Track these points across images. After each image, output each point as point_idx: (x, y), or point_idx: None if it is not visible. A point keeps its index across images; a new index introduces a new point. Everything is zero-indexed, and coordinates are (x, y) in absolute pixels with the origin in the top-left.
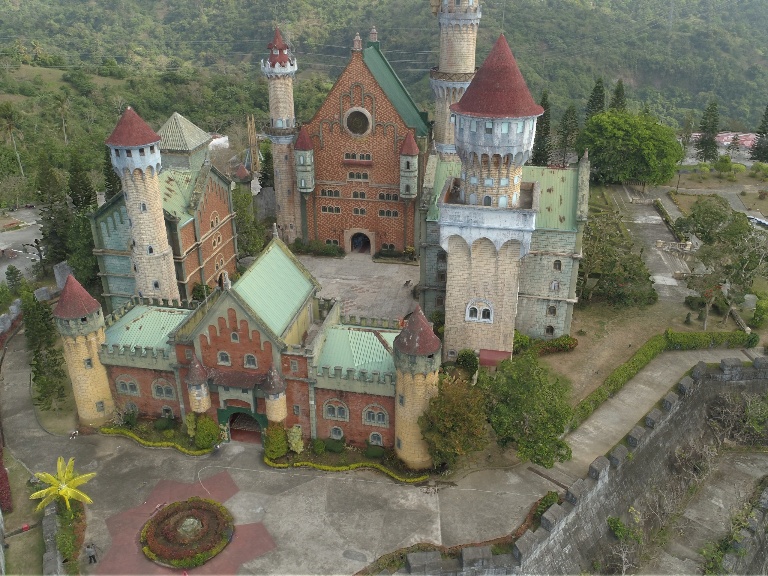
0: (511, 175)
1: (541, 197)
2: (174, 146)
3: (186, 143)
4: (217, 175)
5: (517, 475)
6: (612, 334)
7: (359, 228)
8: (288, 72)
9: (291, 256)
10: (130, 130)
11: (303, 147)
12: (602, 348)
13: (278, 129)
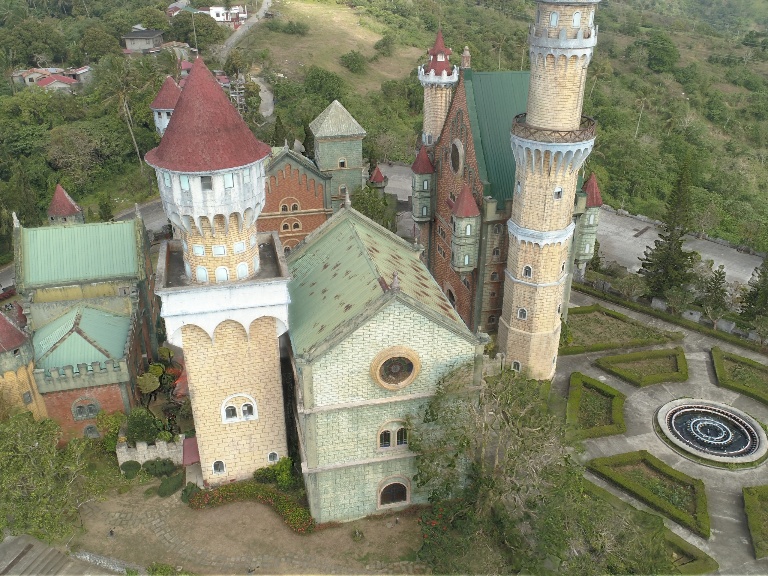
0: (189, 240)
1: (335, 309)
2: (315, 129)
3: (319, 129)
4: (302, 165)
5: (16, 537)
6: (380, 573)
7: (451, 285)
8: (432, 82)
9: (137, 238)
10: (159, 94)
11: (414, 168)
12: (328, 567)
13: (418, 143)
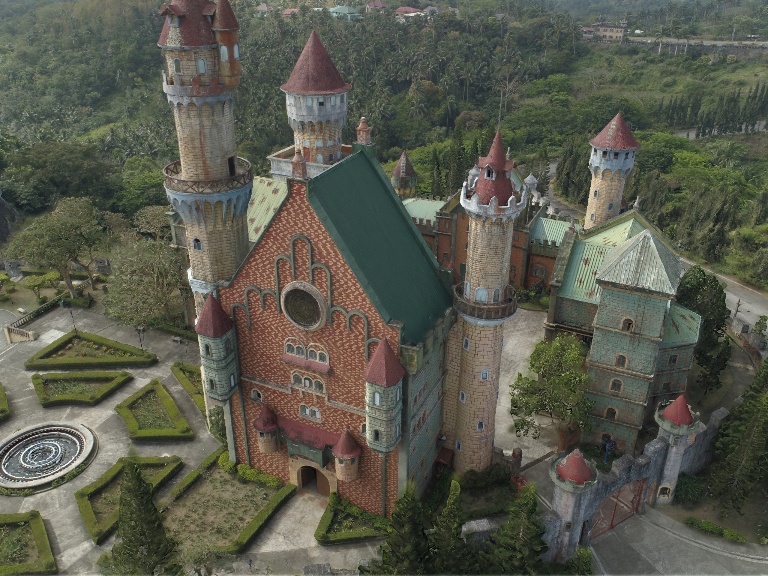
0: None
1: None
2: None
3: None
4: None
5: None
6: None
7: None
8: None
9: None
10: None
11: None
12: None
13: None
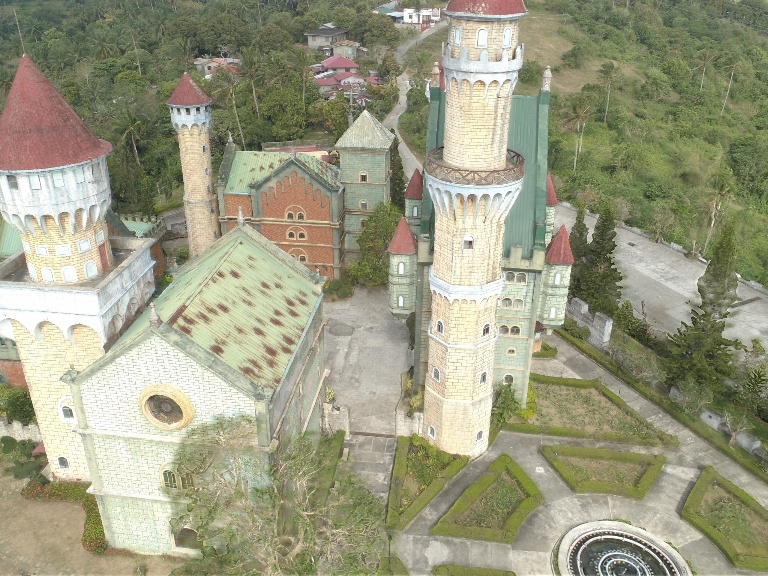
0: None
1: None
2: None
3: (341, 139)
4: None
5: None
6: None
7: None
8: None
9: None
10: None
11: None
12: None
13: None
